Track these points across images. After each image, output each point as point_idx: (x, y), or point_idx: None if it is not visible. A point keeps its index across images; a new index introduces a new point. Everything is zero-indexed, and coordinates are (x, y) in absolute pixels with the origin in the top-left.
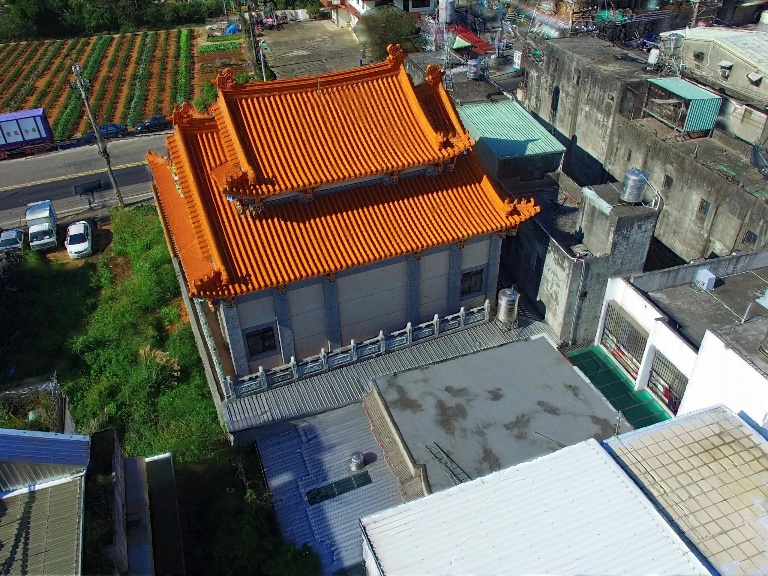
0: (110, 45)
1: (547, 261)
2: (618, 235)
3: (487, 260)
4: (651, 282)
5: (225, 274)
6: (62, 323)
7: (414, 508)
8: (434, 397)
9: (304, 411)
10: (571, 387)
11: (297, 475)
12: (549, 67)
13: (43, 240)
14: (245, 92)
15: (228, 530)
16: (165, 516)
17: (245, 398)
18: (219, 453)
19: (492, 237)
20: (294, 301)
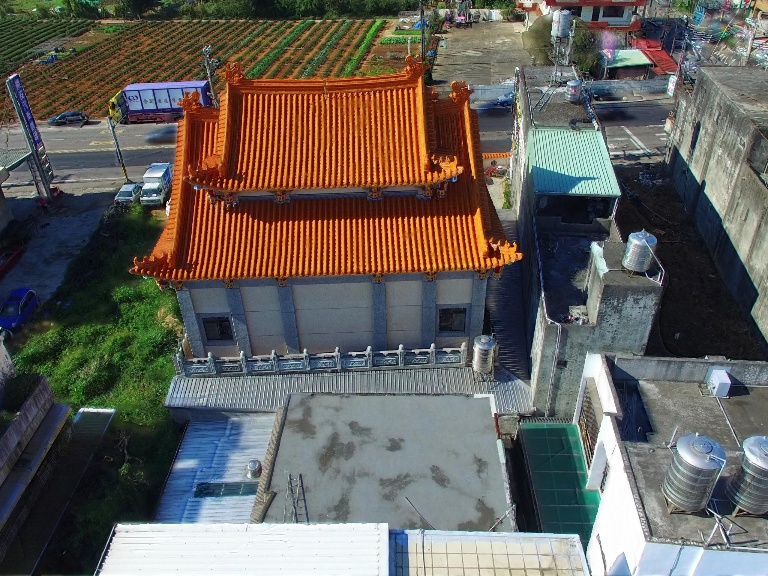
0: (308, 29)
1: (537, 316)
2: (606, 305)
3: (470, 300)
4: (643, 369)
5: (168, 258)
6: (124, 272)
7: (168, 531)
8: (333, 428)
9: (237, 406)
10: (480, 461)
11: (201, 464)
12: (696, 98)
13: (151, 197)
14: (252, 87)
15: (102, 494)
16: (70, 464)
17: (194, 378)
18: (156, 423)
19: (474, 276)
20: (249, 298)
